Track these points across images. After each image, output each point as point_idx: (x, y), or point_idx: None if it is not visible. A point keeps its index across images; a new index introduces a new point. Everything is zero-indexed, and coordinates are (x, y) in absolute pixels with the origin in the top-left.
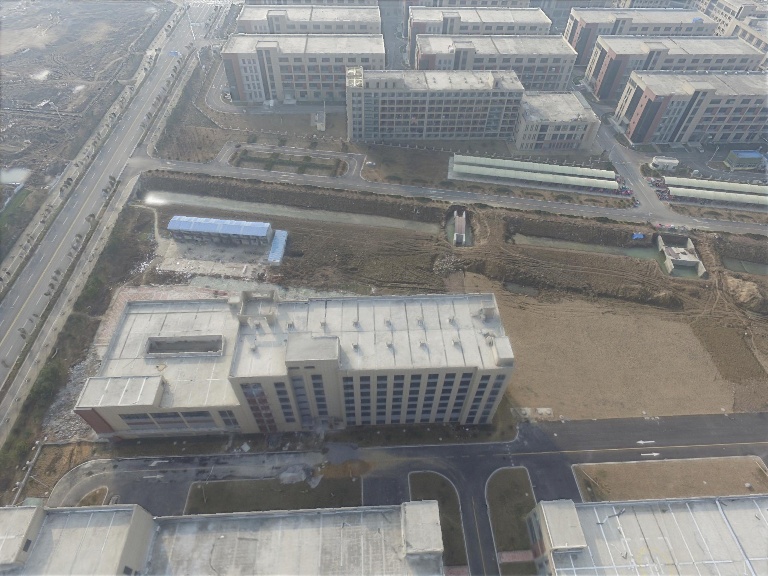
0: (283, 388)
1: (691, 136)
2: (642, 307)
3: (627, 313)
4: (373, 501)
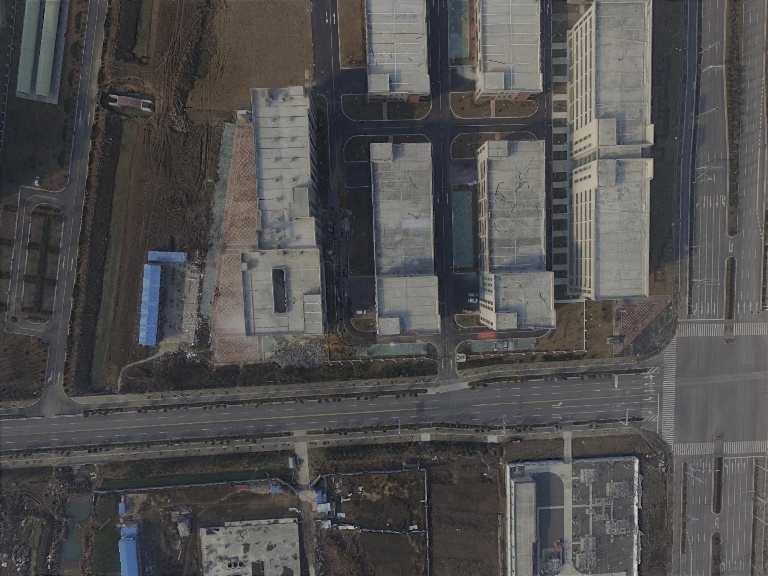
0: None
1: None
2: None
3: None
4: (359, 181)
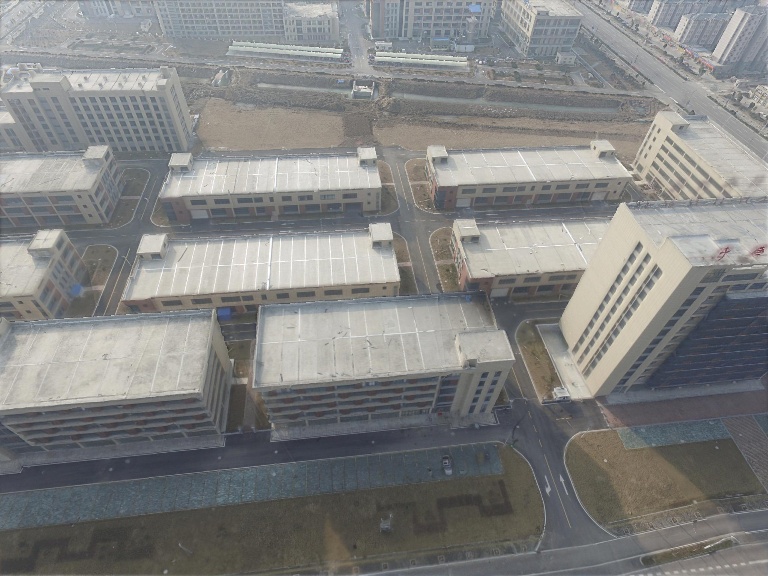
0: (35, 105)
1: (413, 32)
2: (318, 110)
3: (306, 113)
4: None
